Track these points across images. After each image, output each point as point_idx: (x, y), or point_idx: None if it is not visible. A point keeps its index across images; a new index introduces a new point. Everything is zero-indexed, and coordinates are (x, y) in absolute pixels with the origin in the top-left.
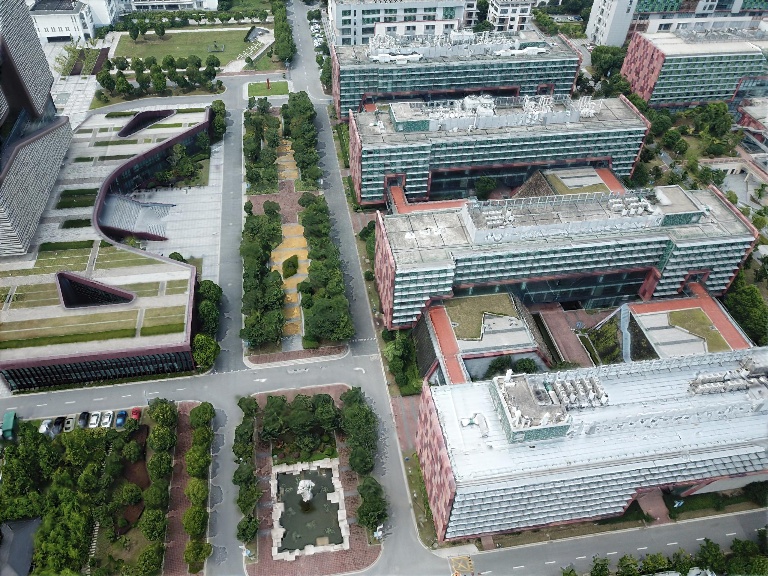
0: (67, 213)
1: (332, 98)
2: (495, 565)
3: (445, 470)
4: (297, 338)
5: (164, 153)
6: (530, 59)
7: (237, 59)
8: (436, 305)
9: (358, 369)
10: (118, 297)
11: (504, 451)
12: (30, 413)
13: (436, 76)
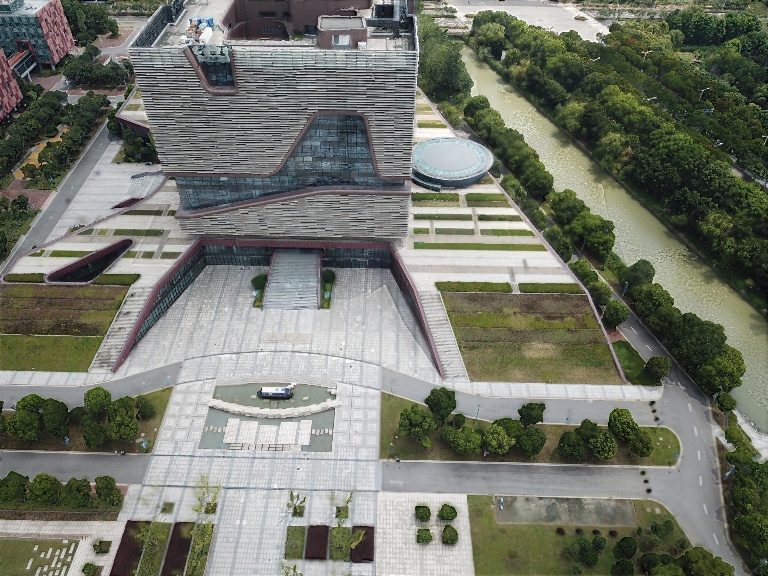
0: None
1: None
2: None
3: None
4: None
5: None
6: None
7: None
8: None
9: None
10: None
11: (29, 3)
12: None
13: None
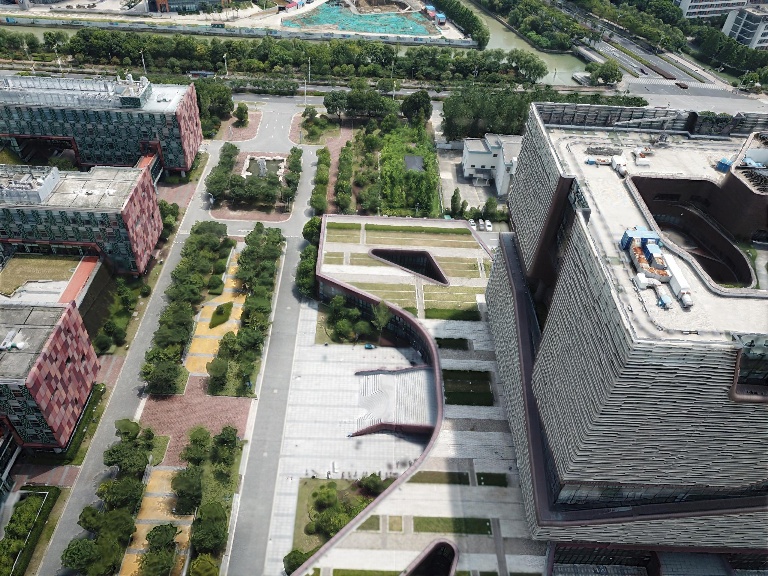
0: (472, 363)
1: None
2: None
3: None
4: (239, 250)
5: None
6: None
7: None
8: None
9: None
10: None
11: (158, 91)
12: None
13: None
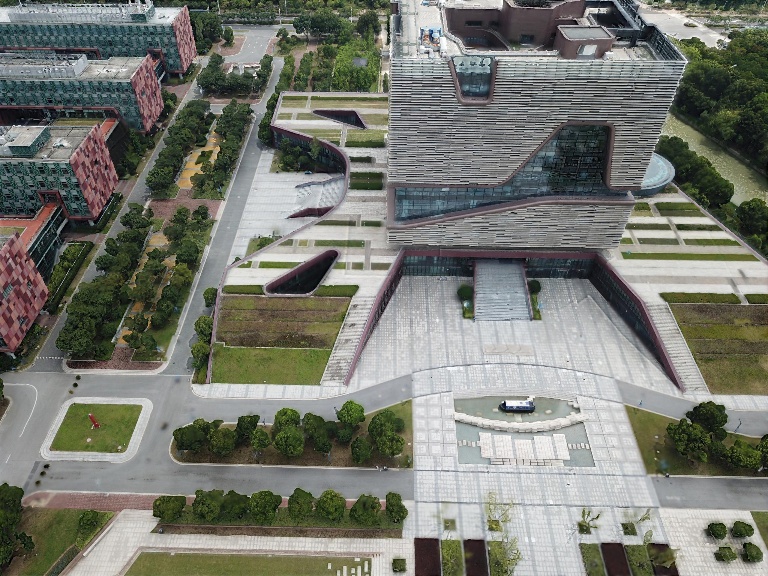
0: (372, 169)
1: (7, 389)
2: None
3: None
4: None
5: None
6: None
7: None
8: None
9: None
10: None
11: (159, 12)
12: None
13: None
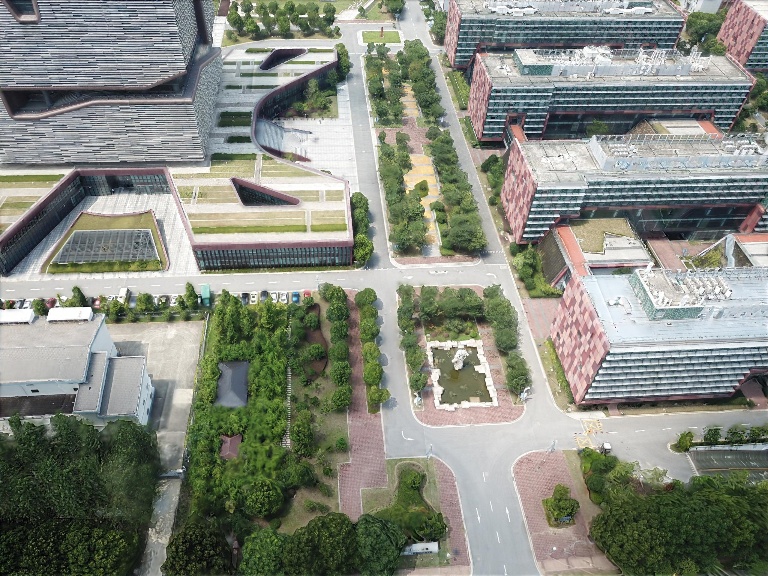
0: (229, 131)
1: (441, 48)
2: (620, 428)
3: (599, 334)
4: (435, 247)
5: (300, 87)
6: (637, 18)
7: (348, 9)
8: (562, 224)
9: (490, 274)
10: (283, 201)
11: (646, 325)
12: (219, 288)
13: (548, 30)
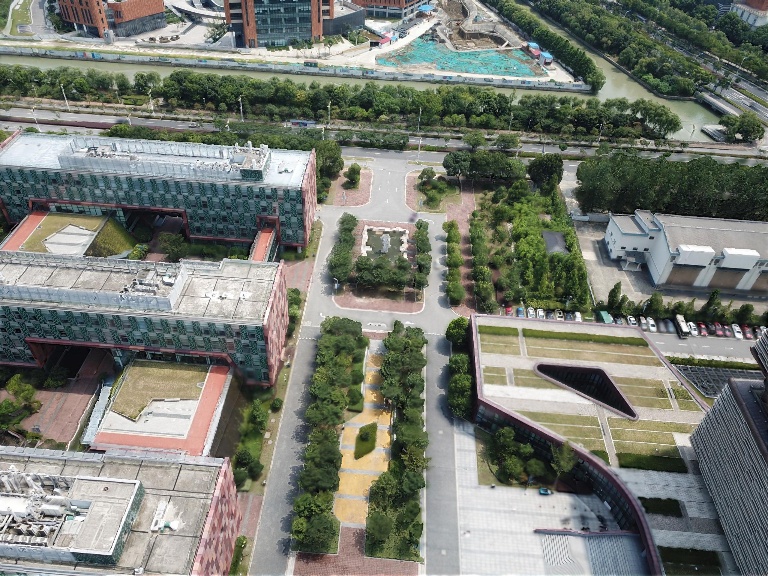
0: (691, 537)
1: None
2: None
3: None
4: (373, 351)
5: None
6: None
7: None
8: None
9: None
10: None
11: (277, 159)
12: None
13: None
